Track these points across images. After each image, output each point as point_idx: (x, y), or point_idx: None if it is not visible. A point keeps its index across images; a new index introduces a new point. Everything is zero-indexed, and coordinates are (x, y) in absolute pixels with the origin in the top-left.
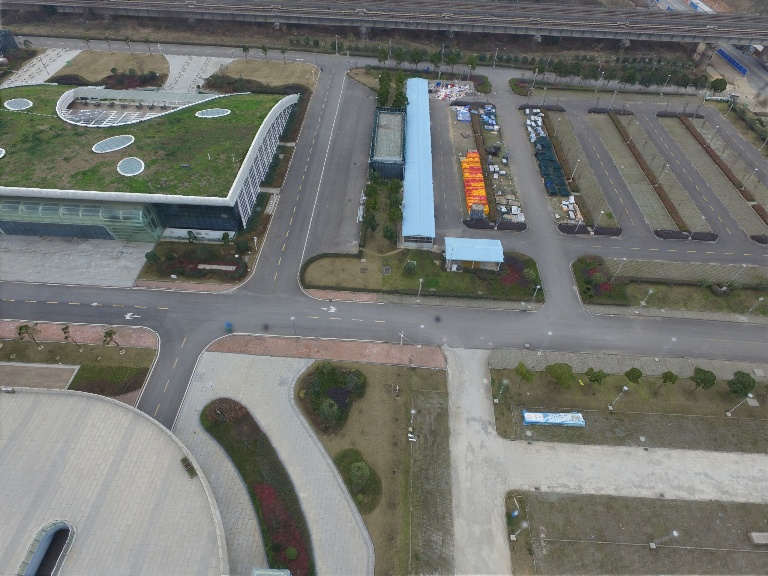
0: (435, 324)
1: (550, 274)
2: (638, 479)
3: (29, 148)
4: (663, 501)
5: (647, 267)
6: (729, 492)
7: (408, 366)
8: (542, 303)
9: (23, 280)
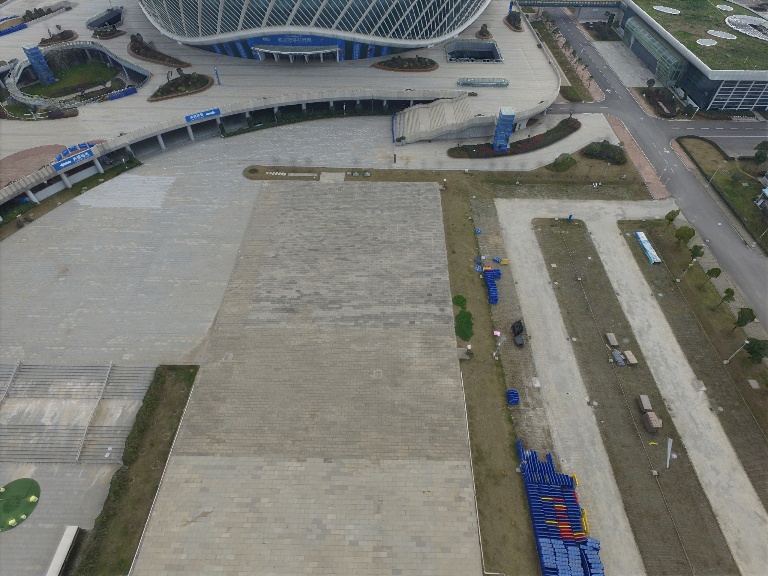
0: (691, 195)
1: None
2: (624, 284)
3: (689, 17)
4: (614, 293)
5: None
6: (642, 336)
7: (644, 182)
8: (766, 255)
9: (607, 61)
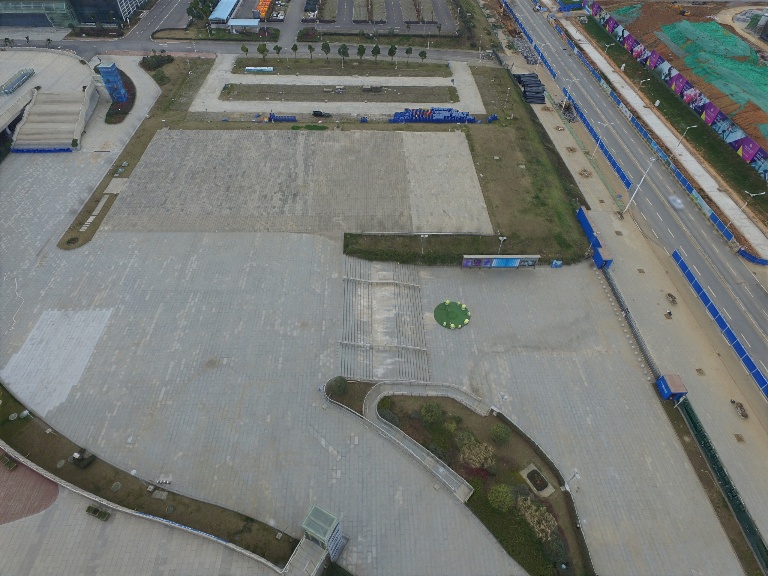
0: (216, 48)
1: (286, 34)
2: (287, 81)
3: None
4: (294, 85)
5: (339, 31)
6: (325, 83)
7: (197, 57)
8: (275, 42)
9: (3, 39)
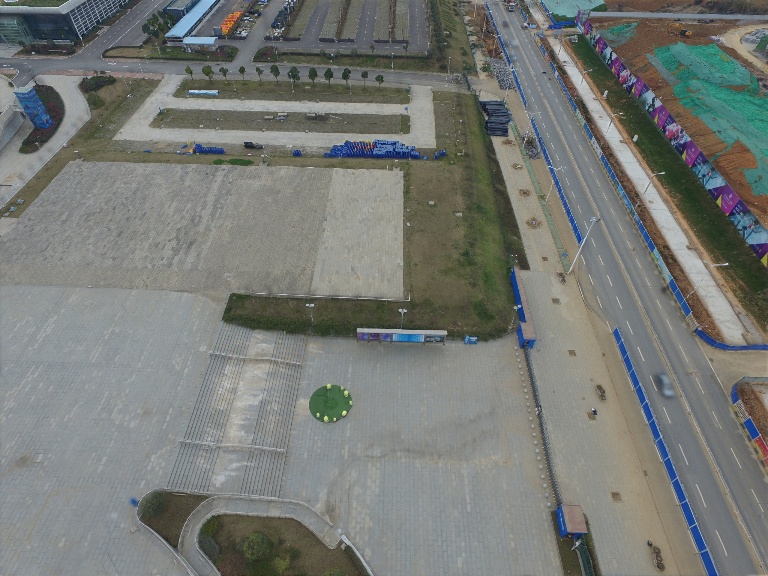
0: (166, 68)
1: (243, 53)
2: (229, 106)
3: None
4: (235, 111)
5: (300, 51)
6: (269, 109)
7: (141, 78)
8: (230, 62)
9: None
